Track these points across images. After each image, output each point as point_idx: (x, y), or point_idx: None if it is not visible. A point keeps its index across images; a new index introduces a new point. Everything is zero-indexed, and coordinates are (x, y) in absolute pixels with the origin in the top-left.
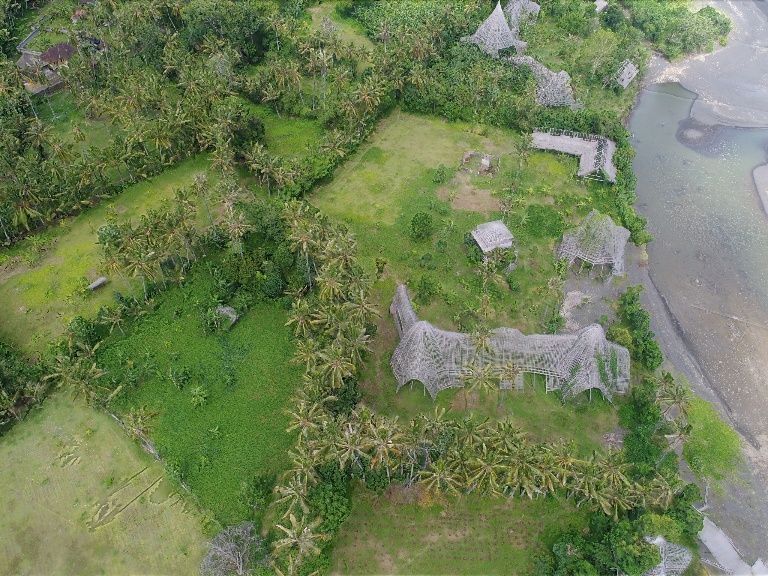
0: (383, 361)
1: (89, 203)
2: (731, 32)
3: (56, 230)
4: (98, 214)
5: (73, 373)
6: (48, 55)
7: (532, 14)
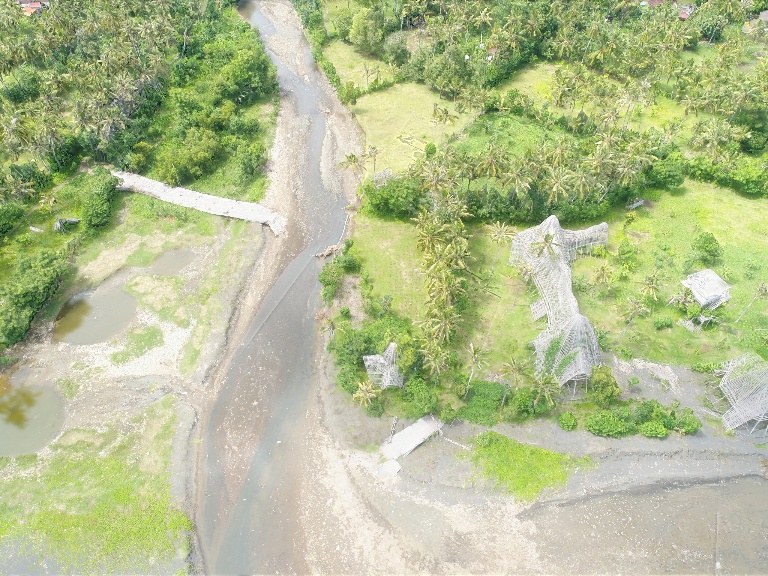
0: None
1: None
2: None
3: None
4: None
5: None
6: None
7: None
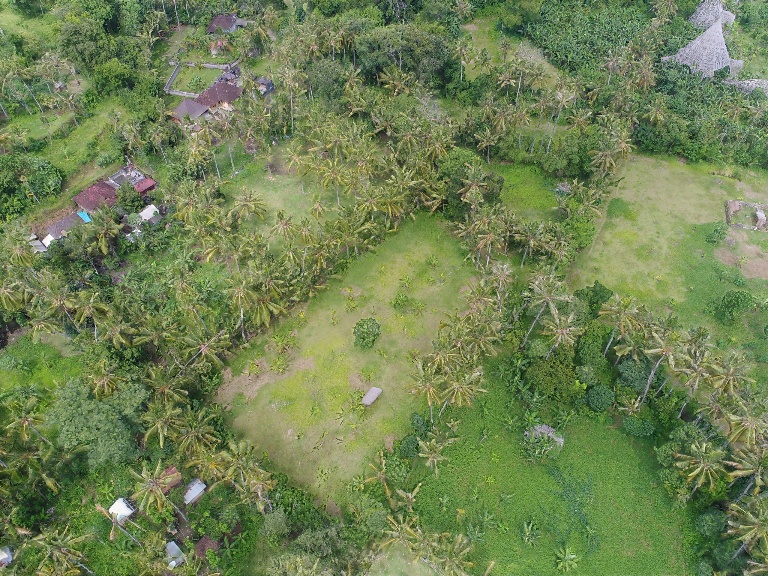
0: (763, 496)
1: (325, 288)
2: None
3: (289, 322)
4: (330, 298)
5: (431, 547)
6: (207, 98)
7: (726, 25)
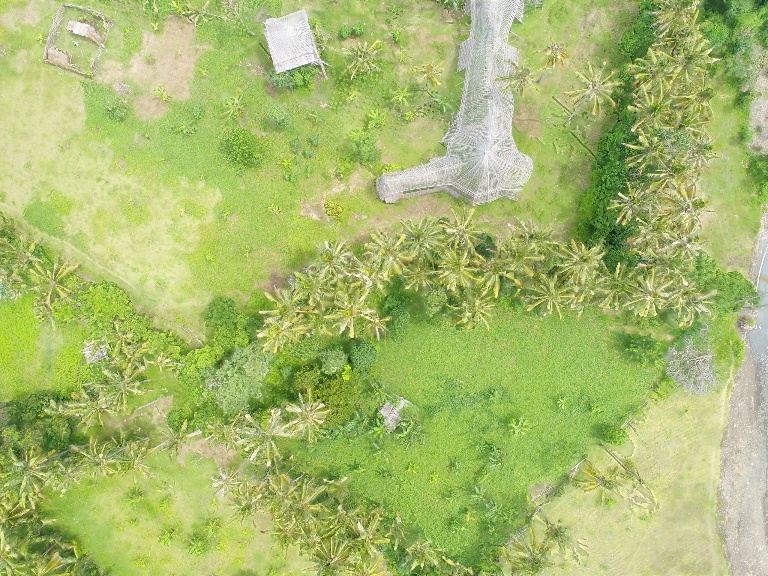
0: None
1: None
2: None
3: None
4: None
5: (522, 575)
6: None
7: None
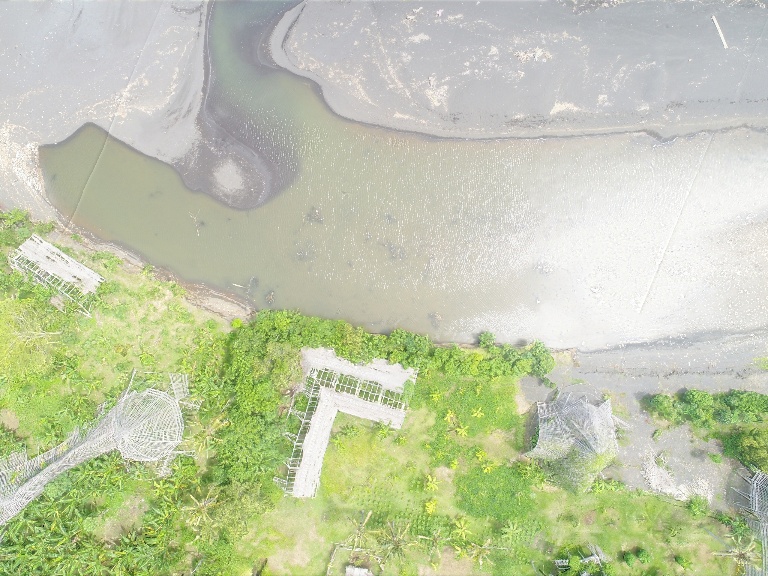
0: None
1: None
2: None
3: None
4: None
5: None
6: None
7: None
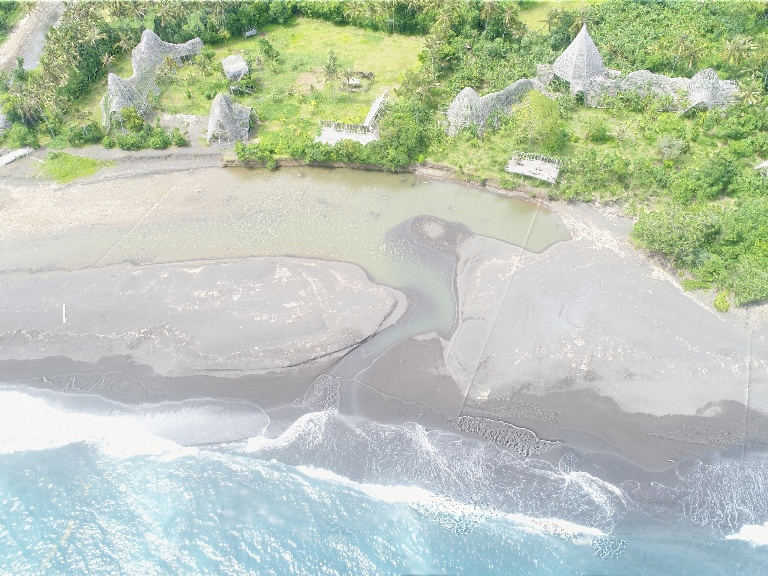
0: None
1: None
2: (761, 315)
3: None
4: None
5: None
6: None
7: (687, 101)
